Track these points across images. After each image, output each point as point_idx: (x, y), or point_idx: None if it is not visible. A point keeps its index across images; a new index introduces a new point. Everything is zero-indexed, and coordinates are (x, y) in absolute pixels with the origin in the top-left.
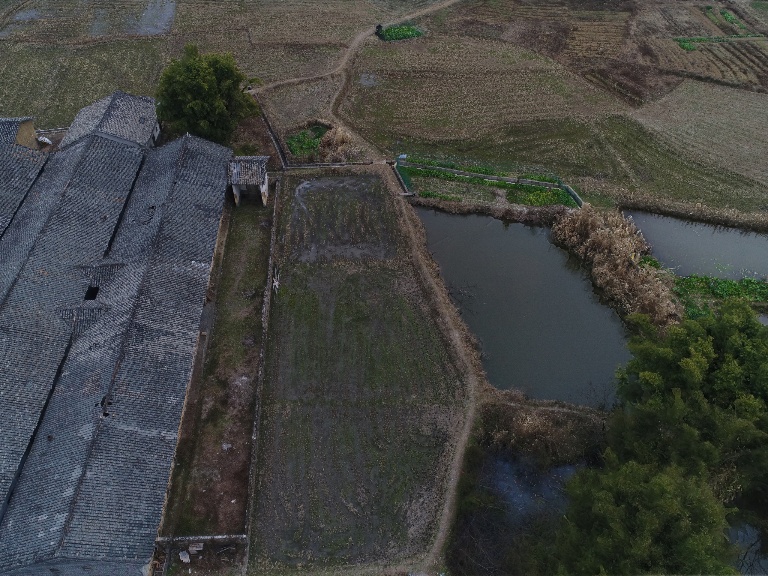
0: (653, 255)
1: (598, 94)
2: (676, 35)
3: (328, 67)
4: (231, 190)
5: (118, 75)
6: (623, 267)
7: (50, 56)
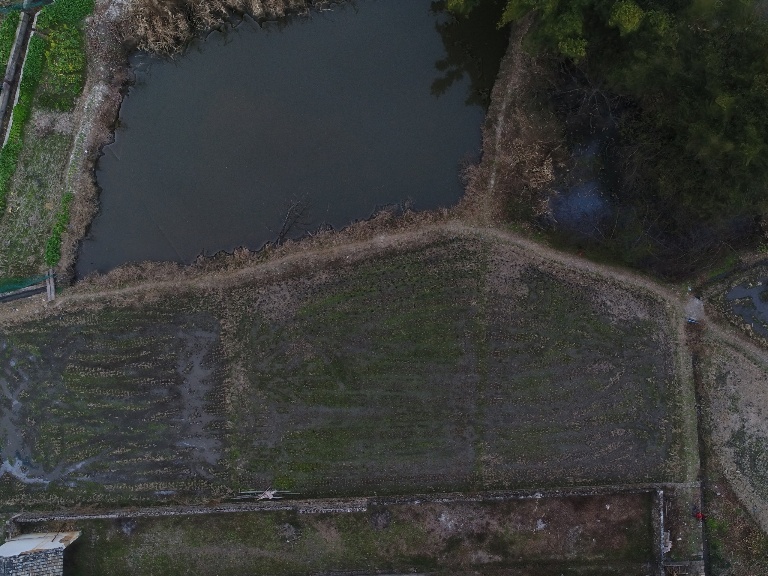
0: None
1: None
2: None
3: None
4: None
5: None
6: None
7: None
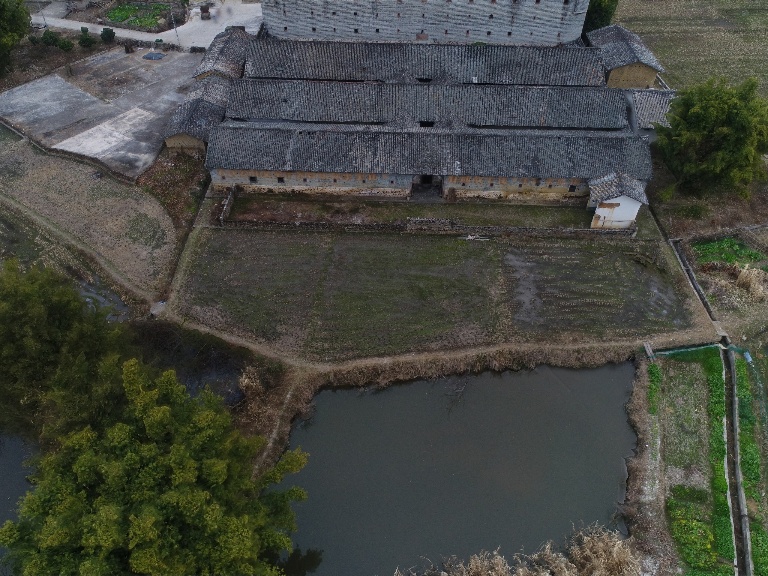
0: None
1: None
2: None
3: None
4: None
5: None
6: None
7: None
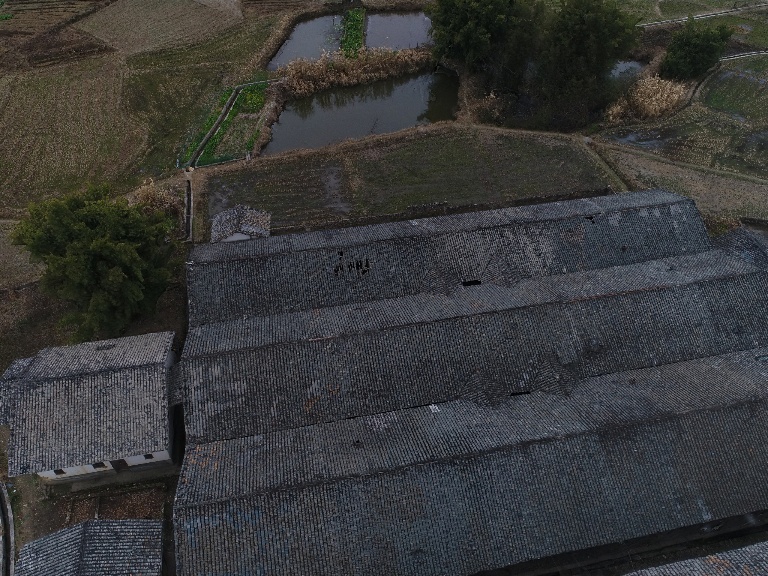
0: None
1: (80, 64)
2: None
3: None
4: None
5: None
6: None
7: None
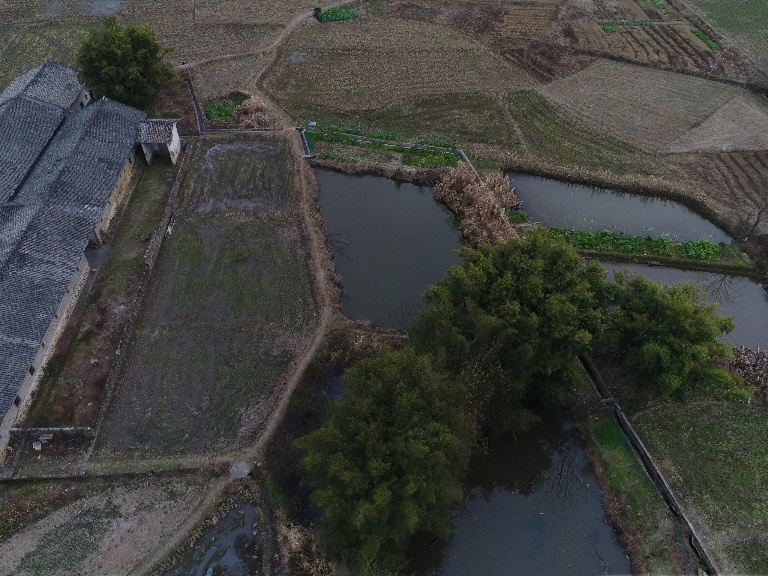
0: (524, 211)
1: (512, 71)
2: (601, 19)
3: (262, 45)
4: (141, 149)
5: (63, 50)
6: (486, 218)
7: (4, 33)
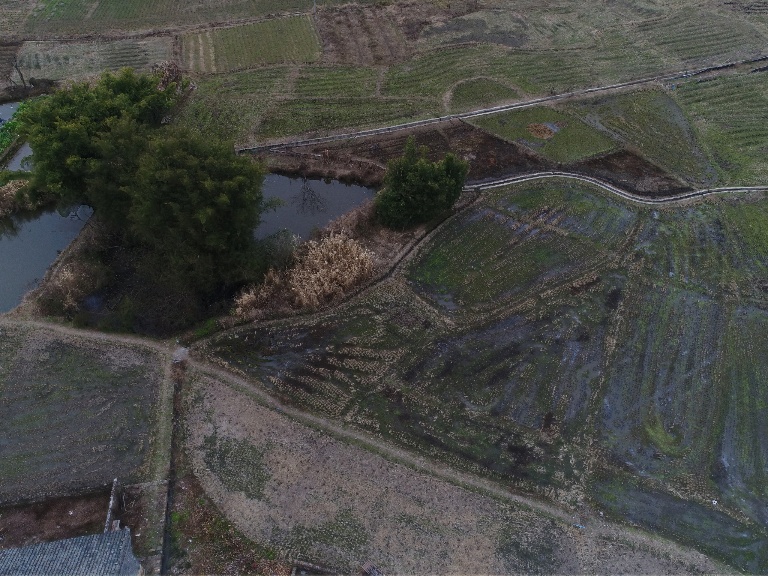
0: None
1: None
2: None
3: None
4: None
5: None
6: None
7: None
